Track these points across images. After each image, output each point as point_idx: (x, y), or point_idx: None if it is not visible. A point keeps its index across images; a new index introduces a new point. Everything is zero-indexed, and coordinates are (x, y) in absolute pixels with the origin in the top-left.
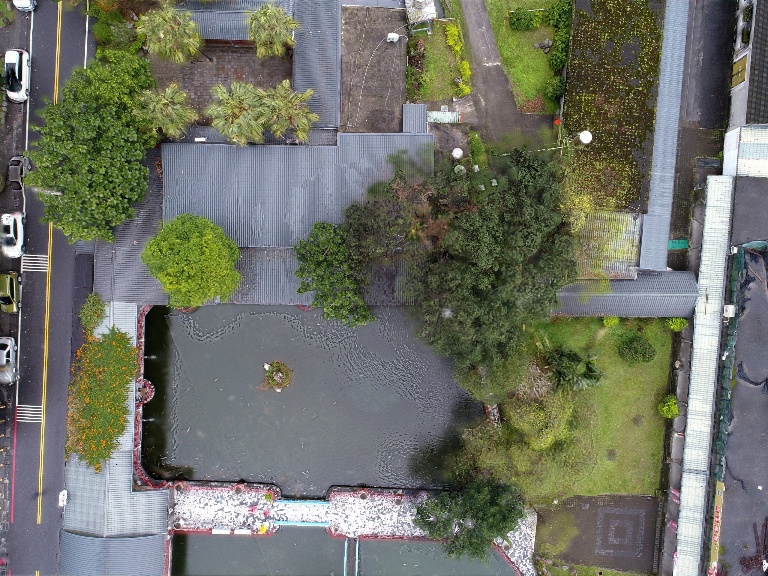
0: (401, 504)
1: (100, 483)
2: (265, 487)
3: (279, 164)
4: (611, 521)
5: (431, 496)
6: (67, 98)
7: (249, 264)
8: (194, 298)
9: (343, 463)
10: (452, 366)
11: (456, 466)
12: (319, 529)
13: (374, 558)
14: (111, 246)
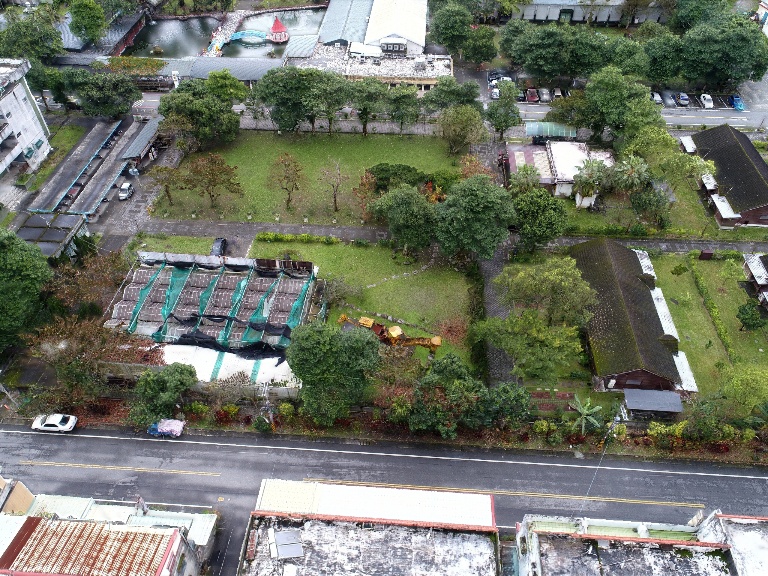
0: (222, 30)
1: (172, 63)
2: (202, 53)
3: (67, 26)
4: (246, 0)
5: (220, 23)
6: (2, 32)
7: (103, 39)
8: (99, 6)
9: (202, 43)
10: (175, 25)
11: (202, 2)
12: (227, 47)
13: (244, 38)
14: (71, 58)
